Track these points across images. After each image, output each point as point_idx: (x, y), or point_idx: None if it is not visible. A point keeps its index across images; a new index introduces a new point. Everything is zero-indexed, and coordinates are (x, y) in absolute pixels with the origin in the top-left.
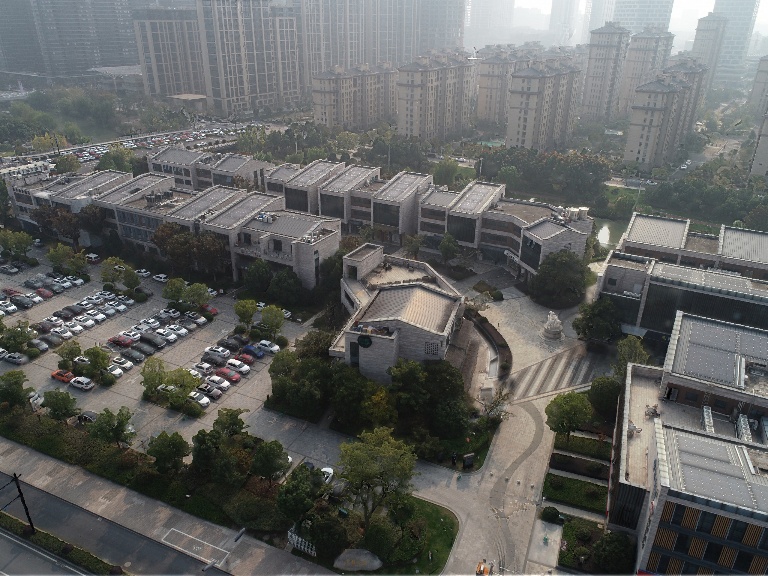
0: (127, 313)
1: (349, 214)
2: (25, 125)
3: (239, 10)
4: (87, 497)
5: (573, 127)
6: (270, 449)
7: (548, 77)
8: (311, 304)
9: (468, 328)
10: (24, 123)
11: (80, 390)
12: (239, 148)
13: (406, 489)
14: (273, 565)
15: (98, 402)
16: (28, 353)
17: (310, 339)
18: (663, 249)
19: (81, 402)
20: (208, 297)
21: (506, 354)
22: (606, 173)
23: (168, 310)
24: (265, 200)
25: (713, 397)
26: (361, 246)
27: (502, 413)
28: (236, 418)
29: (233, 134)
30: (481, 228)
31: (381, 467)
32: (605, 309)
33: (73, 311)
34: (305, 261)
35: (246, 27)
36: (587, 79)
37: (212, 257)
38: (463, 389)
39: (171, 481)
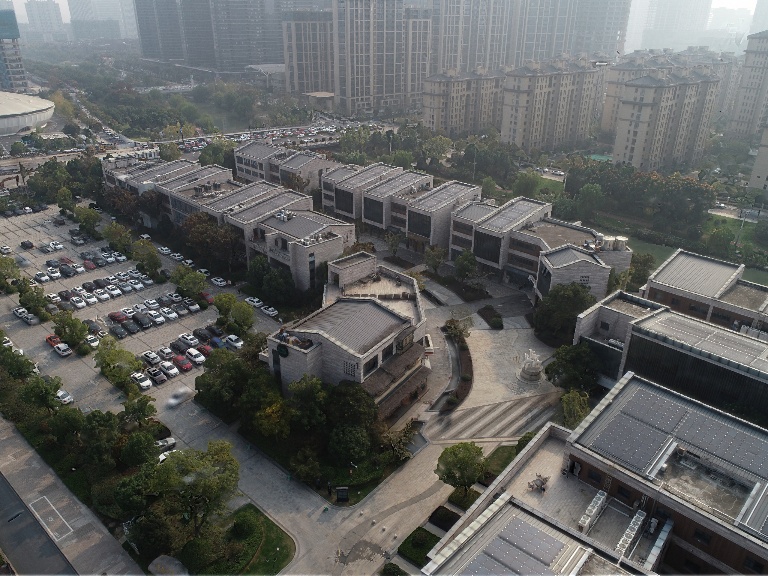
0: (142, 292)
1: (389, 220)
2: (166, 115)
3: (372, 12)
4: (1, 452)
5: (708, 145)
6: (137, 441)
7: (667, 87)
8: (301, 306)
9: (414, 353)
10: (166, 113)
11: (59, 355)
12: (342, 146)
13: (219, 508)
14: (99, 552)
15: (65, 369)
16: (40, 316)
17: (256, 340)
18: (692, 296)
19: (53, 366)
20: (203, 286)
21: (462, 388)
22: (710, 200)
23: (172, 294)
24: (293, 199)
25: (616, 482)
26: (354, 254)
27: (400, 451)
28: (142, 405)
29: (344, 132)
30: (508, 248)
31: (186, 480)
32: (579, 356)
33: (99, 284)
34: (301, 262)
35: (378, 29)
36: (739, 90)
37: (224, 249)
38: (375, 417)
39: (69, 452)
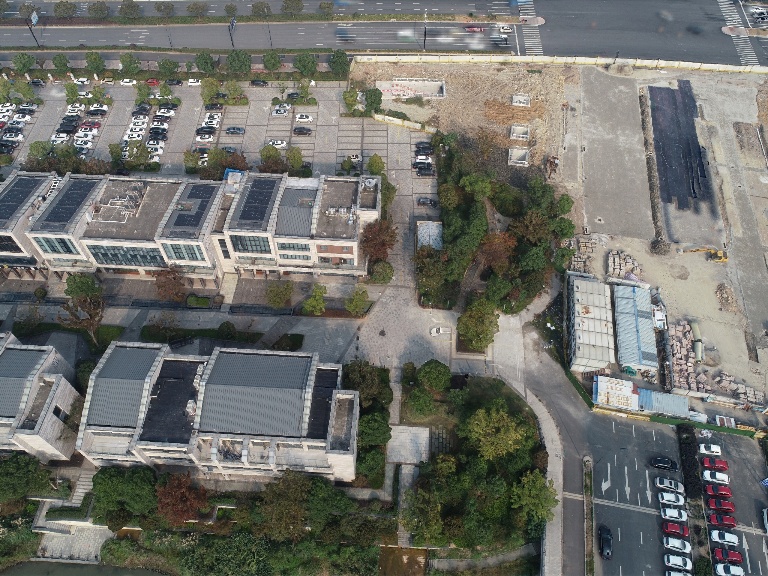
0: None
1: None
2: None
3: None
4: None
5: None
6: None
7: None
8: None
9: None
10: None
11: None
12: None
13: None
14: None
15: None
16: None
17: None
18: None
19: (77, 91)
20: None
21: None
22: None
23: None
24: None
25: None
26: None
27: None
28: None
29: None
30: None
31: None
32: None
33: None
34: None
35: None
36: None
37: None
38: None
39: None
